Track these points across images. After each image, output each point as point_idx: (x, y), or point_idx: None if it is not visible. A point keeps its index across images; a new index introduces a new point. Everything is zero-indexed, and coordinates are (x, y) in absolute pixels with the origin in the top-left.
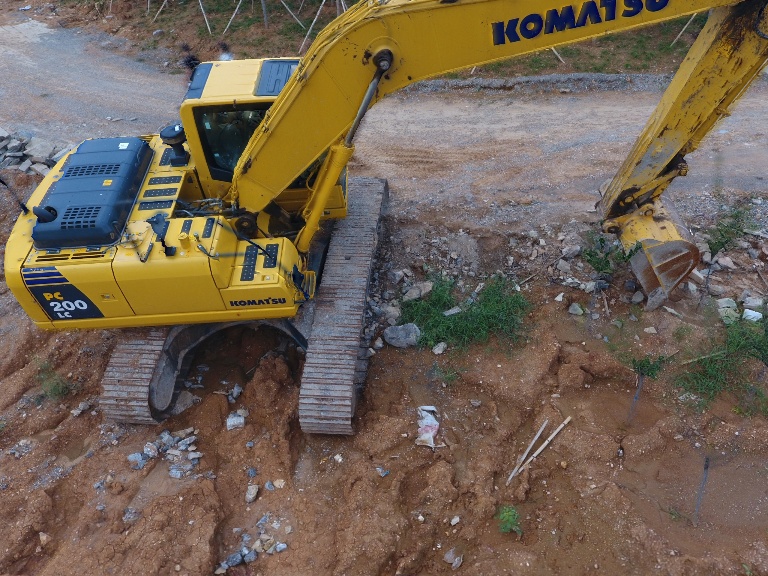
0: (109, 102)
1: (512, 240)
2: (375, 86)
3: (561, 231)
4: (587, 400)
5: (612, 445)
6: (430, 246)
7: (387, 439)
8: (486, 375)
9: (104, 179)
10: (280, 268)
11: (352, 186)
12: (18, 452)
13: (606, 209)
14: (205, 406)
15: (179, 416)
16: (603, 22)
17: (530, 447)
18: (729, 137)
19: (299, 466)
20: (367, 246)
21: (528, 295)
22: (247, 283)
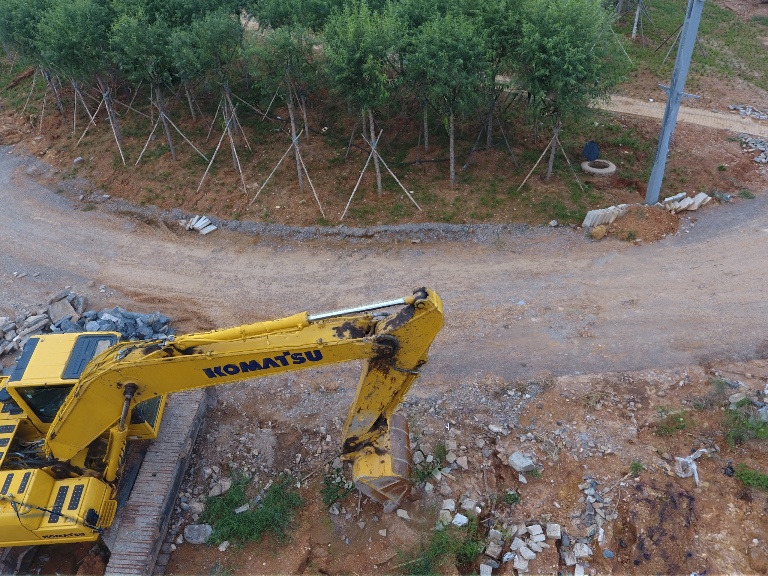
0: (20, 251)
1: (304, 437)
2: (128, 403)
3: None
4: None
5: None
6: (239, 443)
7: None
8: (252, 573)
9: None
10: (81, 509)
11: (178, 393)
12: None
13: (341, 446)
14: None
15: None
16: (282, 366)
17: None
18: (523, 311)
19: None
20: (172, 462)
21: (305, 492)
22: (53, 525)
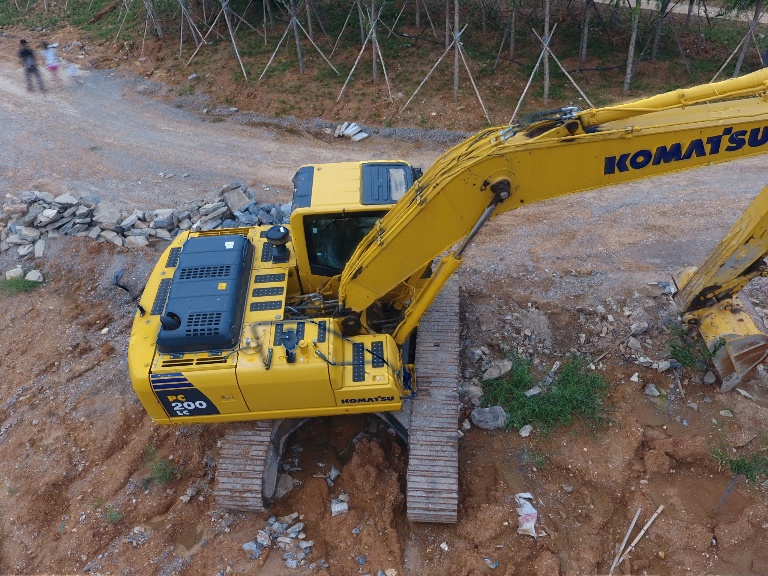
0: (158, 156)
1: (582, 316)
2: (492, 211)
3: (626, 305)
4: (674, 486)
5: (706, 536)
6: (504, 323)
7: (490, 528)
8: (574, 459)
9: (218, 282)
10: (388, 367)
11: None
12: (135, 540)
13: (686, 302)
14: (307, 490)
15: (281, 500)
16: (707, 155)
17: (627, 536)
18: None
19: (407, 554)
20: (454, 332)
21: (603, 374)
22: (359, 384)
